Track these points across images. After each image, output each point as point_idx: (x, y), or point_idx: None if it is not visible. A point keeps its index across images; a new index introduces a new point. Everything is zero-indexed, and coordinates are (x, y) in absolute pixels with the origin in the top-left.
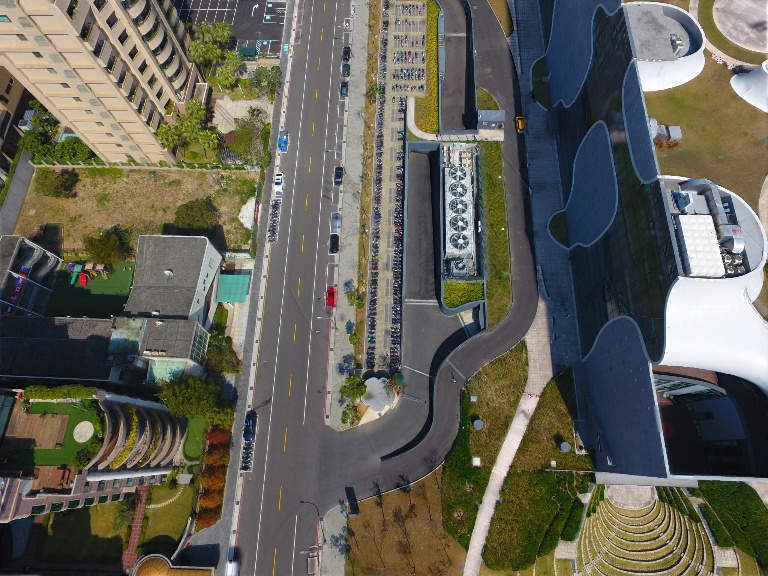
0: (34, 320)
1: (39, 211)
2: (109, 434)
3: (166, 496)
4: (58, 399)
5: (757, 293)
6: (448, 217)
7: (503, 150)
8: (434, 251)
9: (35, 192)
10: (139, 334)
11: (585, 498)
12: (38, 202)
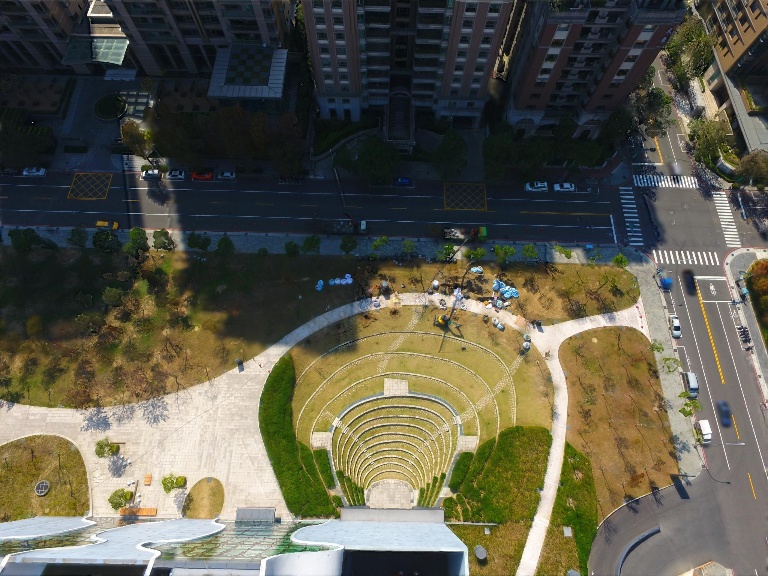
0: None
1: None
2: None
3: None
4: None
5: None
6: None
7: None
8: None
9: None
10: None
11: (446, 492)
12: None
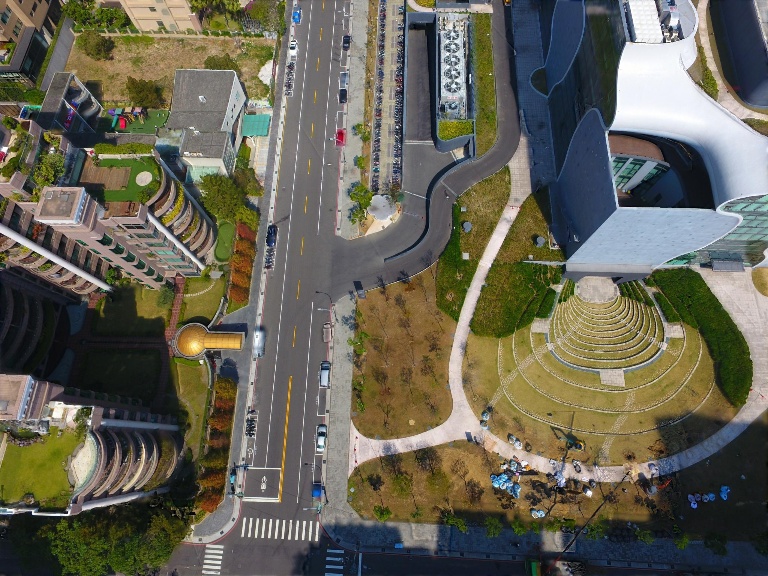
0: (87, 135)
1: (80, 71)
2: (165, 182)
3: (201, 287)
4: (122, 155)
5: (690, 63)
6: (443, 69)
7: (492, 20)
8: (430, 104)
9: (76, 56)
10: (179, 141)
11: (557, 289)
12: (79, 64)
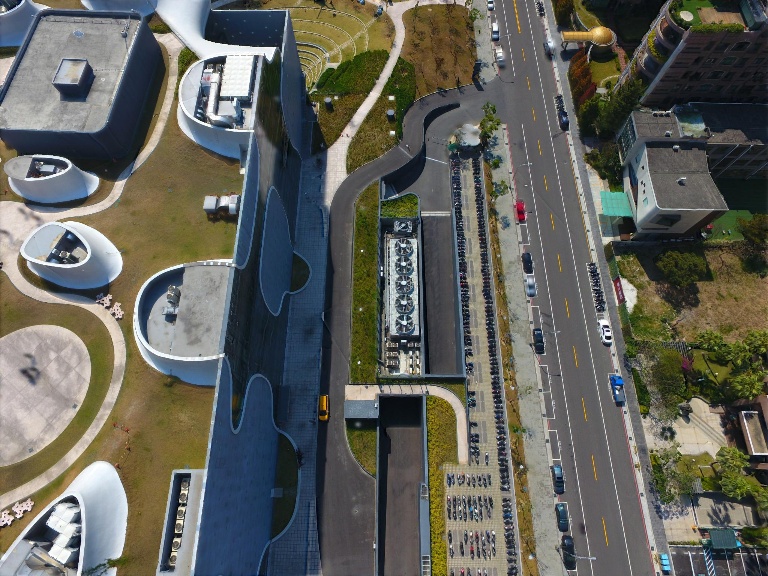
0: None
1: None
2: None
3: None
4: None
5: None
6: (415, 275)
7: (348, 371)
8: (424, 264)
9: None
10: None
11: None
12: None
